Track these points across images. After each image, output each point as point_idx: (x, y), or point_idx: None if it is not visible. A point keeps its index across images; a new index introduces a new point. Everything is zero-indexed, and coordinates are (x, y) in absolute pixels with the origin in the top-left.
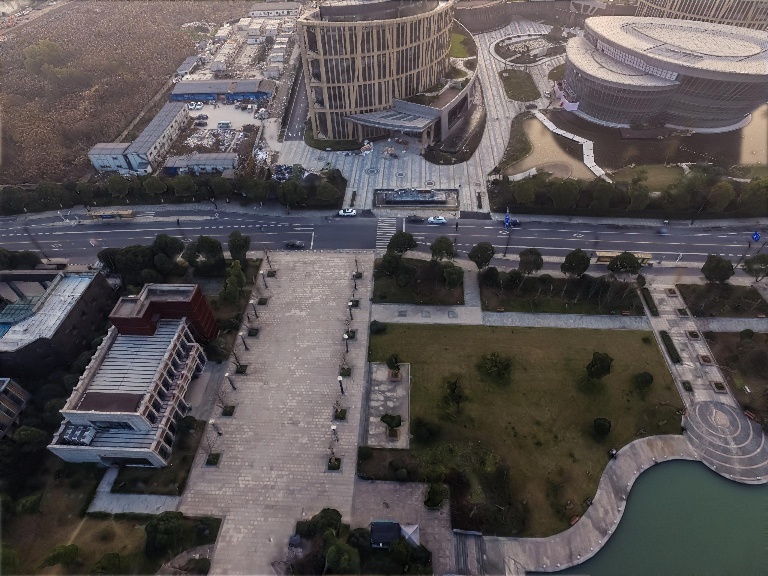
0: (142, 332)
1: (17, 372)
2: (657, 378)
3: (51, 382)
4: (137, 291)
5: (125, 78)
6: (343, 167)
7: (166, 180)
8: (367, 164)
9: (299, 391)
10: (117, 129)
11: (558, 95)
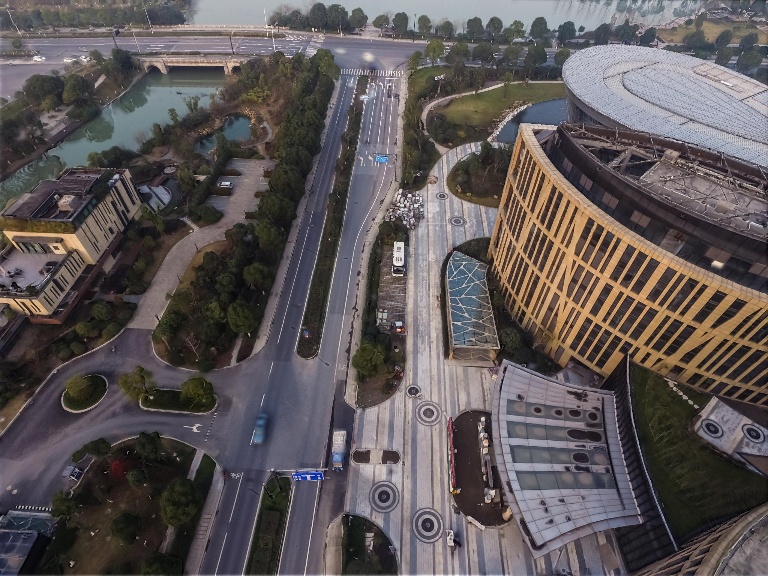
0: None
1: None
2: (665, 35)
3: None
4: None
5: None
6: None
7: None
8: None
9: None
10: None
11: None
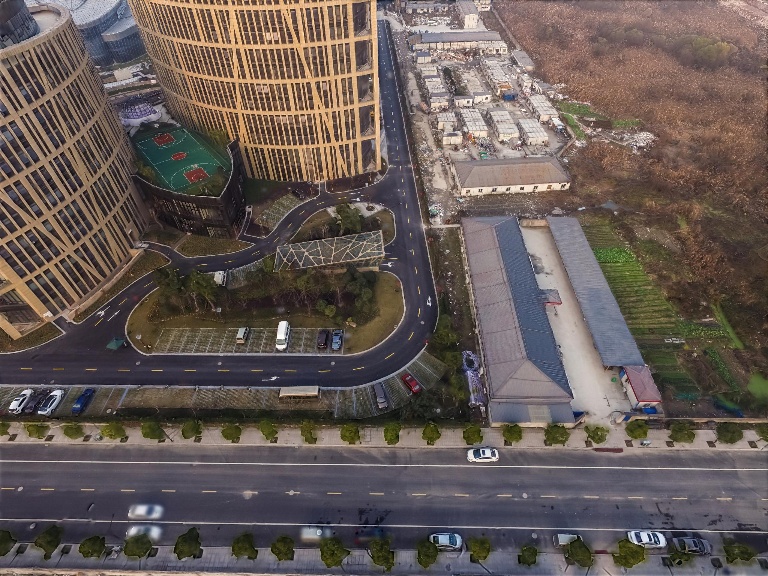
0: None
1: None
2: None
3: None
4: None
5: (551, 30)
6: None
7: (439, 1)
8: None
9: None
10: None
11: None
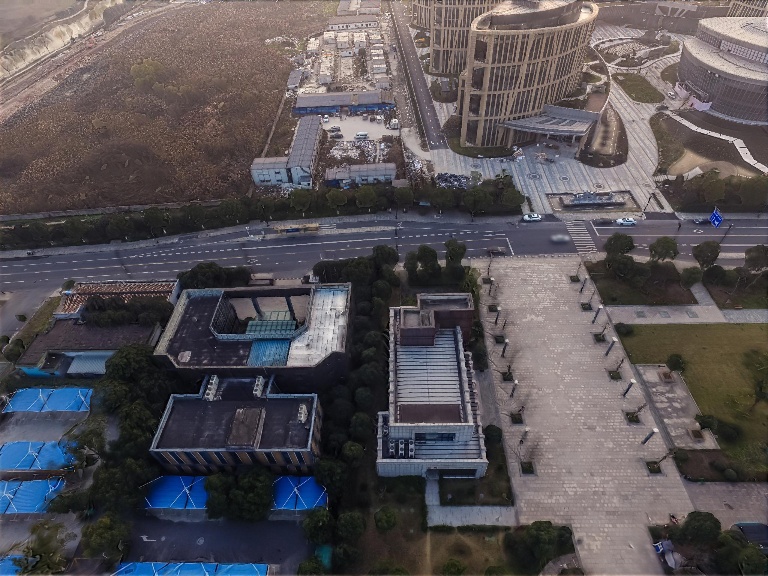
0: (423, 342)
1: (300, 388)
2: None
3: (339, 396)
4: (383, 302)
5: (245, 94)
6: (503, 173)
7: None
8: (526, 169)
9: (578, 396)
10: (258, 144)
11: (684, 96)
